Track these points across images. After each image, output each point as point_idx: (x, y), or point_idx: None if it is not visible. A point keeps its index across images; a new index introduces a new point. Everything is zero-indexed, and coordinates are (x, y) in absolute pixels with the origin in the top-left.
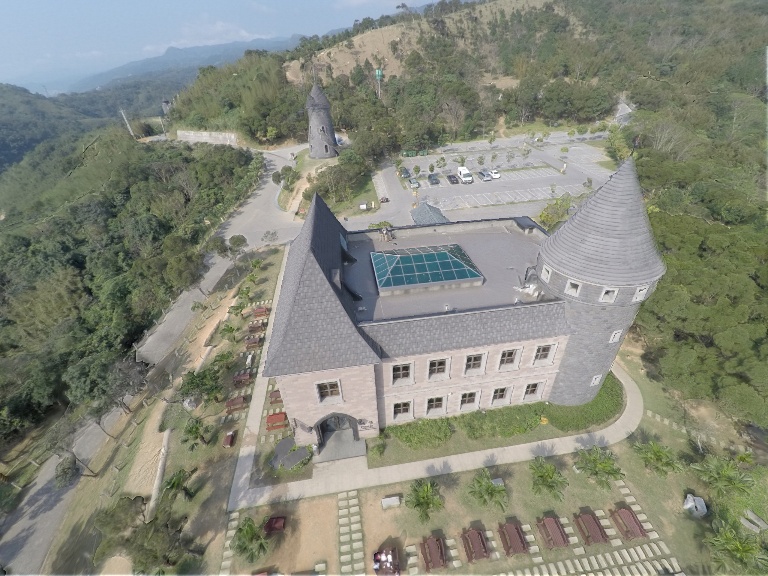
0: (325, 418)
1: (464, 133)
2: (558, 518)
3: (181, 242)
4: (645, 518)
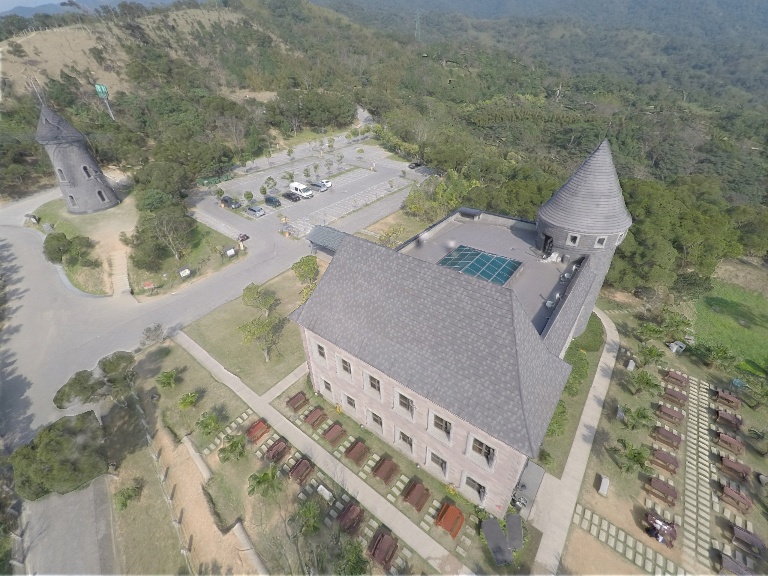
0: None
1: (252, 150)
2: (658, 404)
3: None
4: (674, 370)
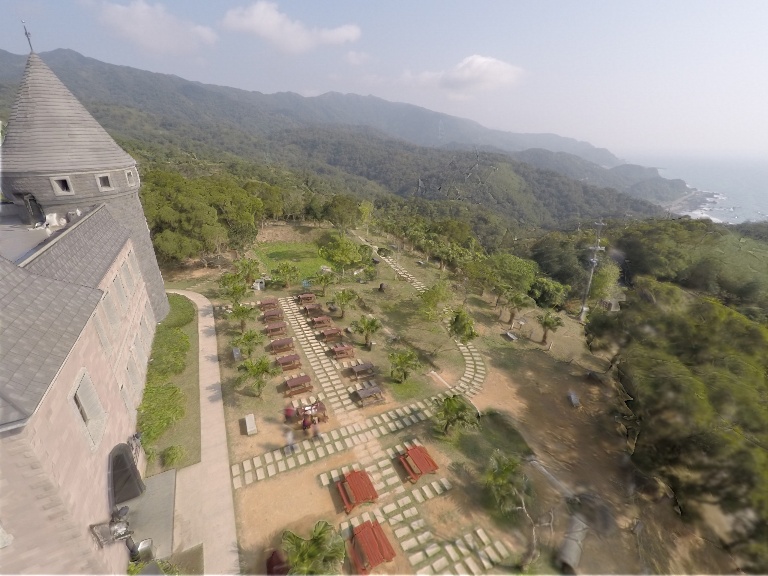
0: (112, 475)
1: None
2: None
3: None
4: None
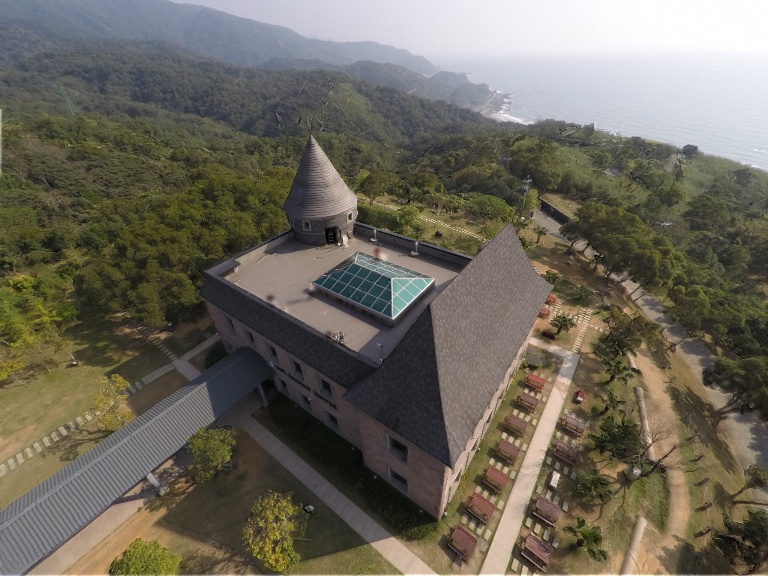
0: None
1: None
2: None
3: None
4: None
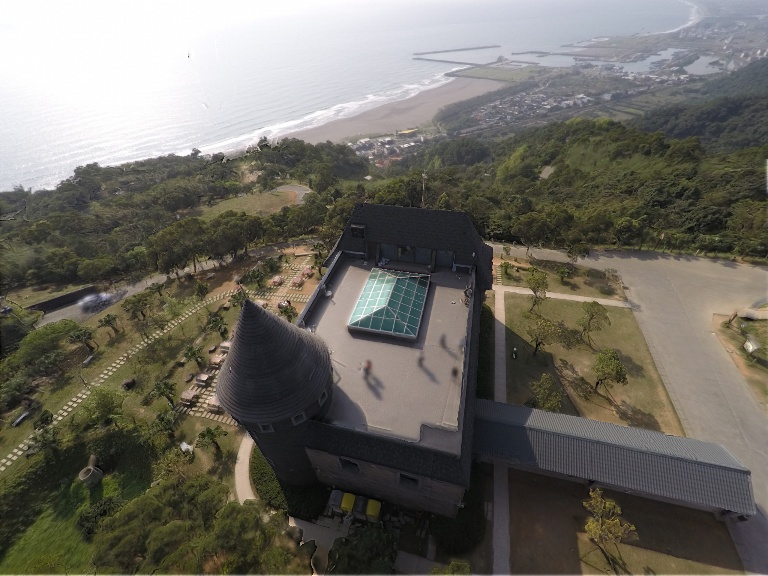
0: None
1: None
2: None
3: (604, 226)
4: None
